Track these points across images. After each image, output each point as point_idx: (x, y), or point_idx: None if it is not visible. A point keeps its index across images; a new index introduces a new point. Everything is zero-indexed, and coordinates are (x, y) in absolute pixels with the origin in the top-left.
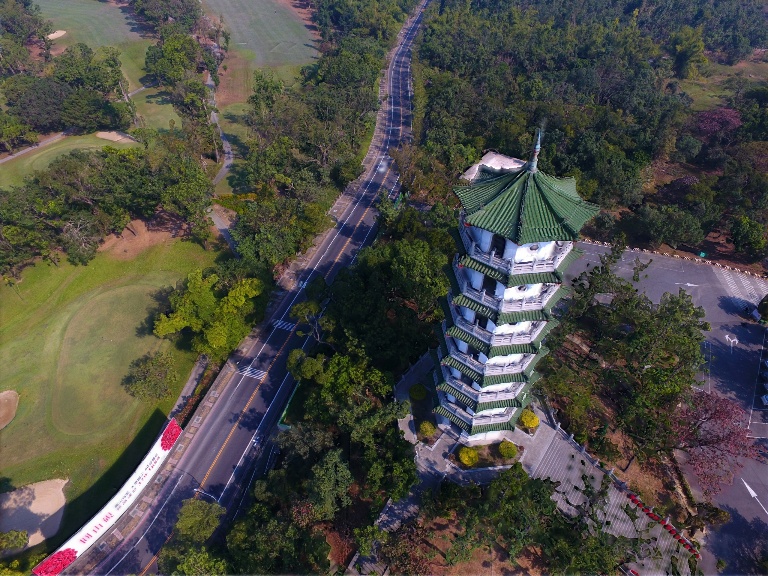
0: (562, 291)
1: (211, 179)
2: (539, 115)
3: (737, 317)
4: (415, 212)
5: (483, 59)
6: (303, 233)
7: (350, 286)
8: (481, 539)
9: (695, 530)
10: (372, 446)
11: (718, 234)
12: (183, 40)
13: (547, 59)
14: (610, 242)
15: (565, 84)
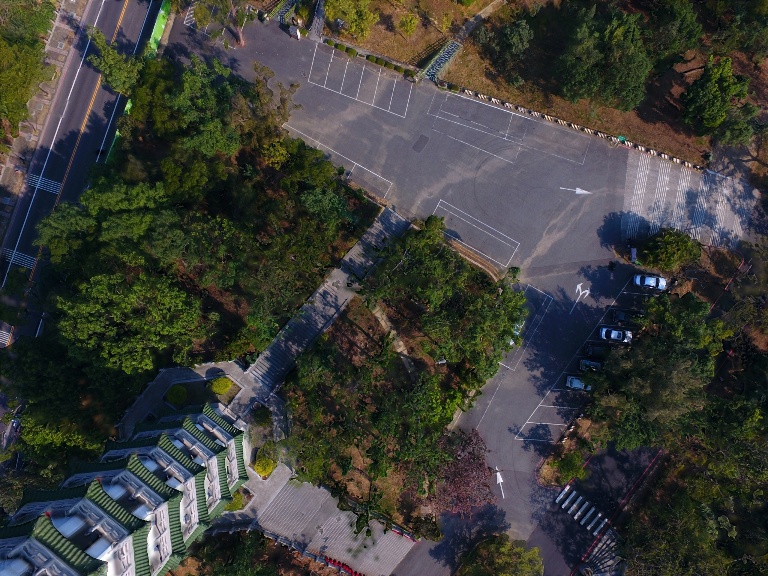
0: None
1: None
2: None
3: (610, 252)
4: None
5: None
6: None
7: (30, 301)
8: None
9: None
10: None
11: (694, 51)
12: None
13: None
14: (509, 85)
15: None
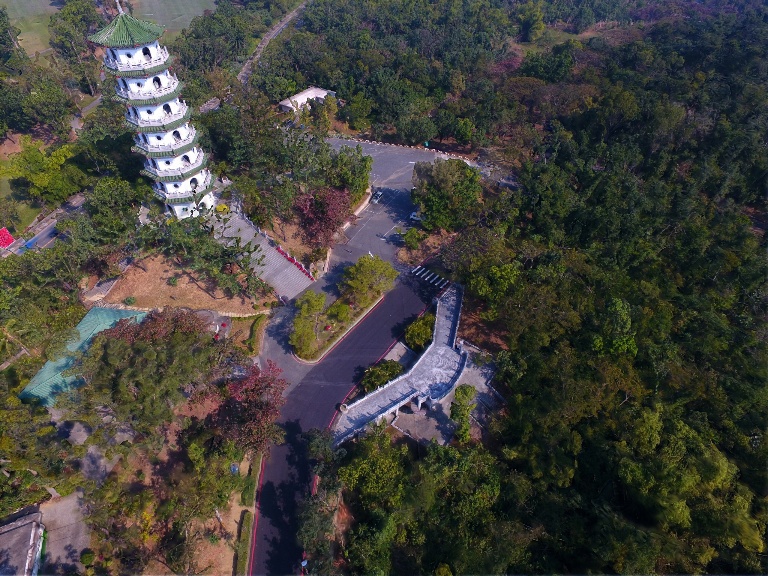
0: (175, 94)
1: (77, 102)
2: (353, 58)
3: None
4: (210, 112)
5: (346, 24)
6: (134, 132)
7: None
8: (155, 250)
9: (310, 264)
10: (110, 216)
11: None
12: (80, 5)
13: (401, 24)
14: None
15: (400, 41)
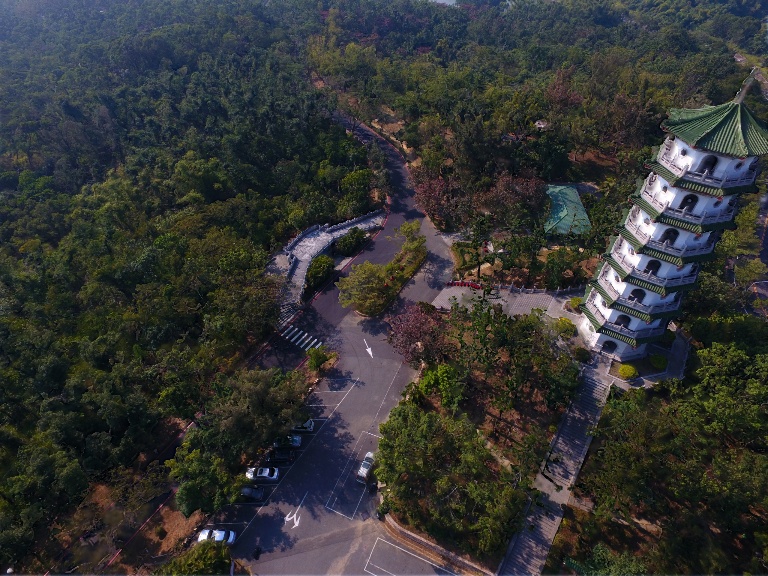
0: None
1: None
2: None
3: (256, 572)
4: None
5: None
6: None
7: None
8: None
9: None
10: None
11: None
12: None
13: None
14: None
15: None
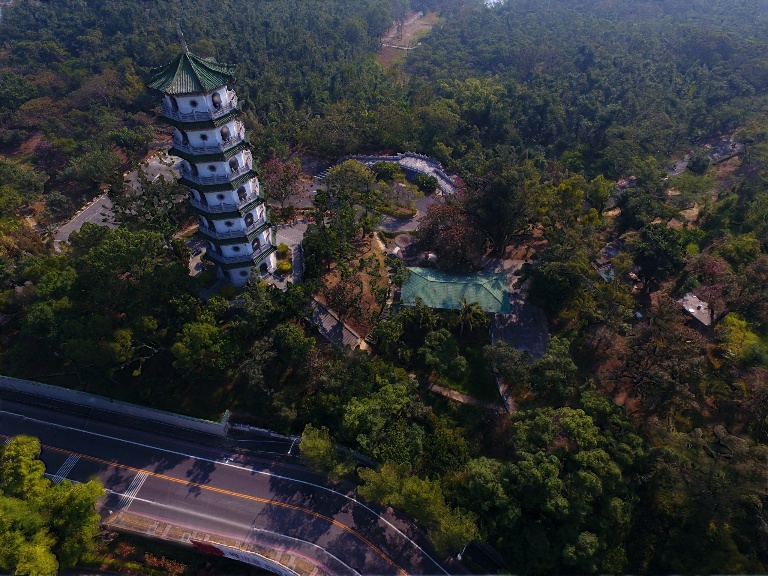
0: None
1: None
2: None
3: None
4: None
5: None
6: None
7: None
8: None
9: None
10: (274, 308)
11: None
12: None
13: None
14: (84, 205)
15: None
